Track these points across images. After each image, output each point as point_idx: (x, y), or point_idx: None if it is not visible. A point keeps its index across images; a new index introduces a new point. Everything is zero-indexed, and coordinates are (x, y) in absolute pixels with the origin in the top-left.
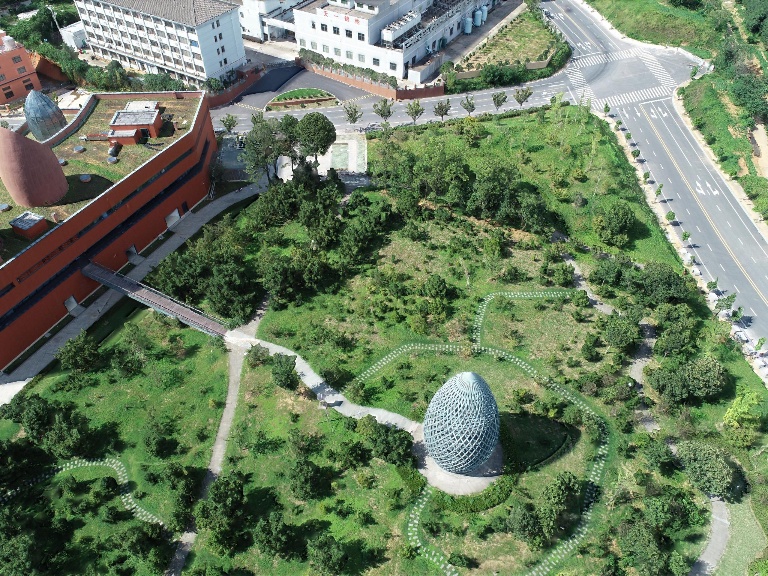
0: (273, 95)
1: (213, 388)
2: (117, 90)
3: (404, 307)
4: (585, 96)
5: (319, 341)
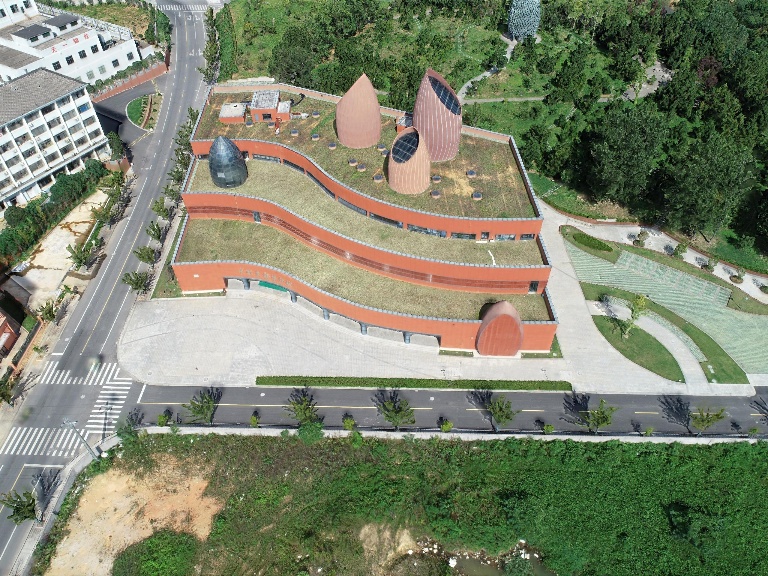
0: (128, 124)
1: (493, 105)
2: (43, 232)
3: (433, 52)
4: (201, 8)
5: (459, 75)
